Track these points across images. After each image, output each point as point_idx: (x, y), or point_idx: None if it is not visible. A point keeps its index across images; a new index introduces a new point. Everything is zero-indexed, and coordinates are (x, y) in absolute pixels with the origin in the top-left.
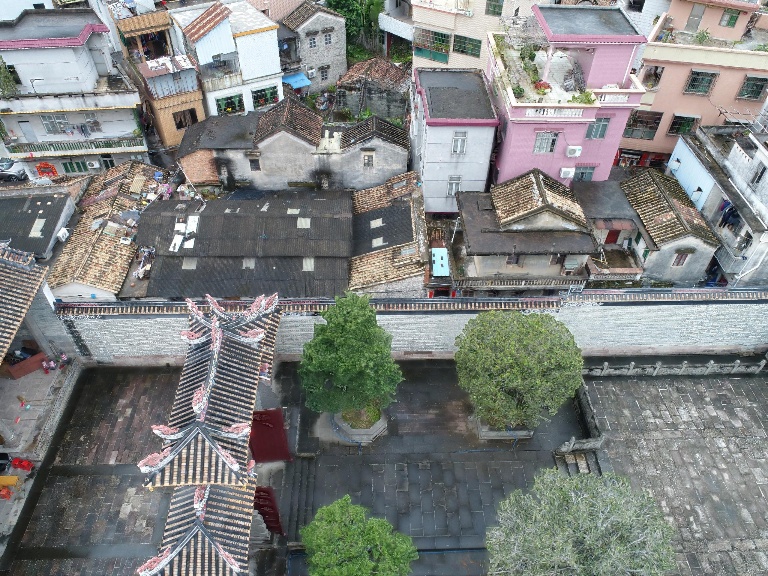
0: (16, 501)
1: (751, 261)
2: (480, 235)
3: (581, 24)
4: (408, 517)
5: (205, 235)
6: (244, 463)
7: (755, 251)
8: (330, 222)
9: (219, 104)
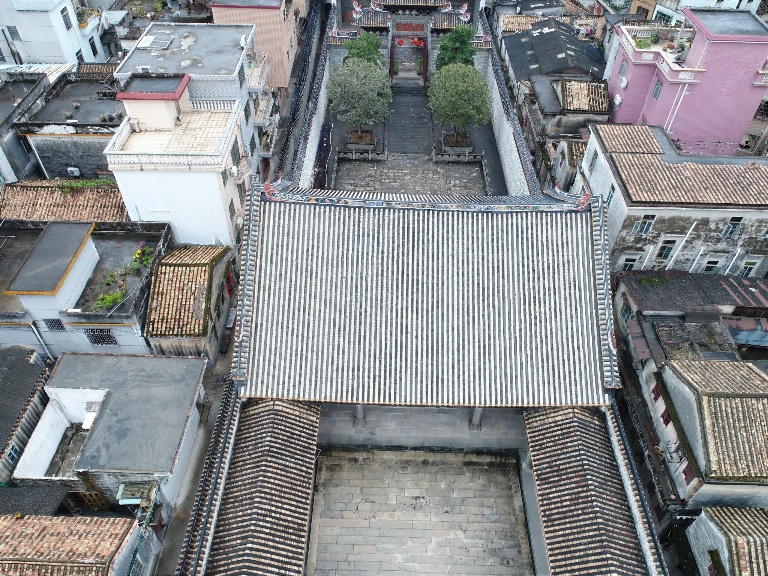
0: (410, 46)
1: None
2: (547, 79)
3: (727, 22)
4: (399, 115)
5: (543, 36)
6: (382, 2)
7: (574, 185)
8: (565, 62)
9: (657, 15)
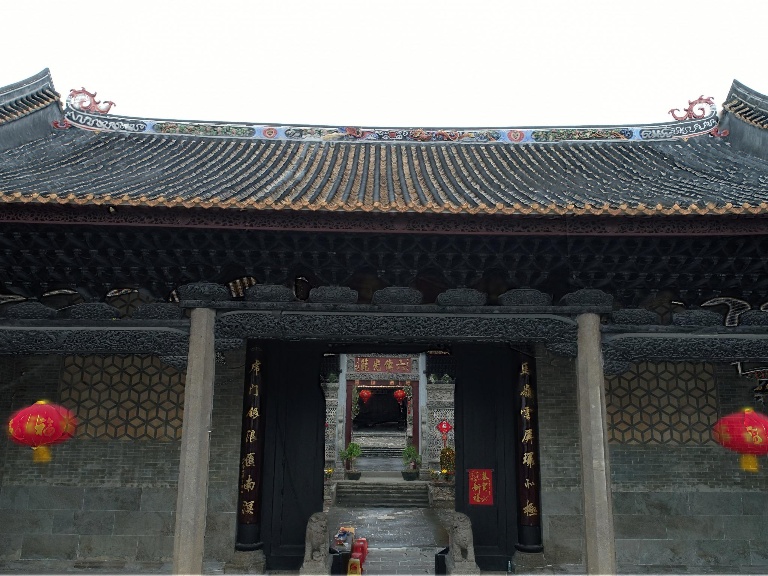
0: None
1: None
2: None
3: None
4: None
5: None
6: None
7: None
8: None
9: None
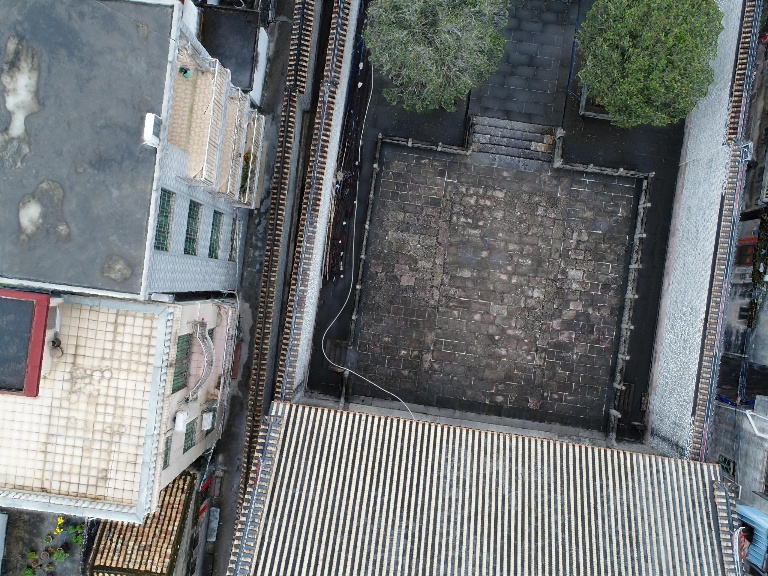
0: None
1: (766, 425)
2: None
3: None
4: None
5: None
6: None
7: None
8: None
9: None
